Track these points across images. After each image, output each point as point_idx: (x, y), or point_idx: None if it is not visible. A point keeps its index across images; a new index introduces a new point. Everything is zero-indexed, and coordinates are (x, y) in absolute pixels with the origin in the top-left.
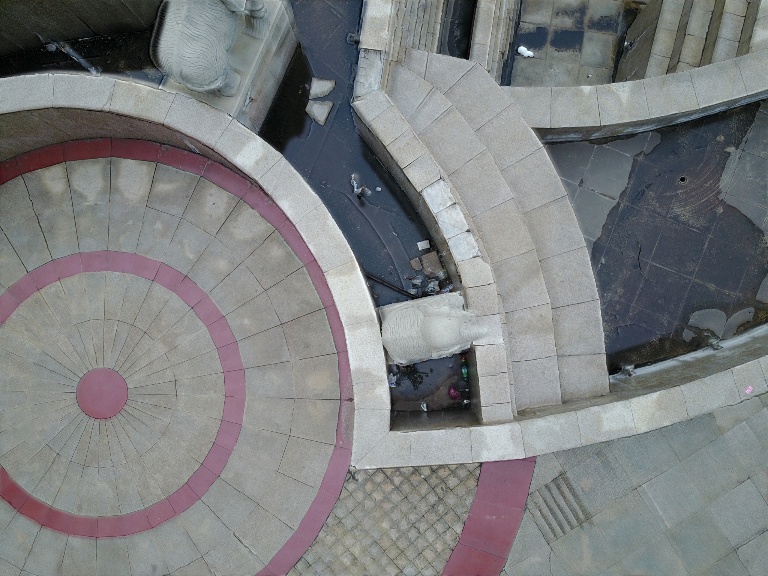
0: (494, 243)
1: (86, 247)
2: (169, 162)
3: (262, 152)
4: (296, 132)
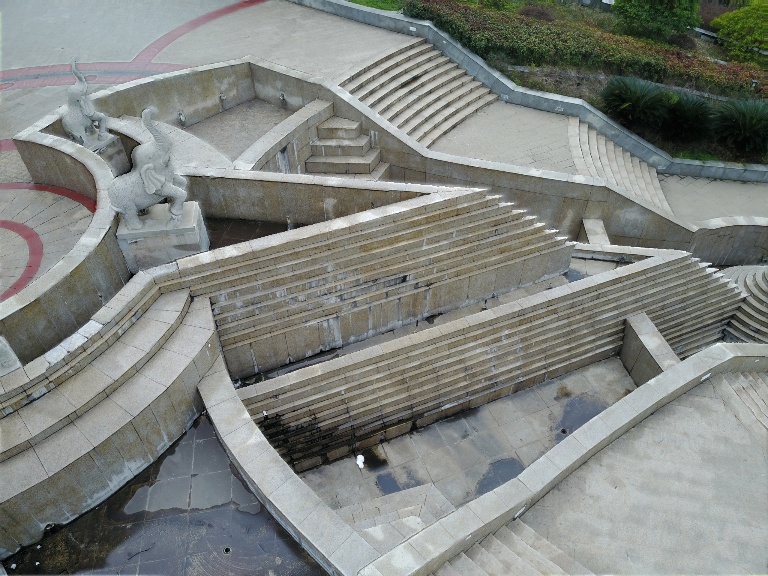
0: (75, 384)
1: (43, 237)
2: None
3: (91, 245)
4: None
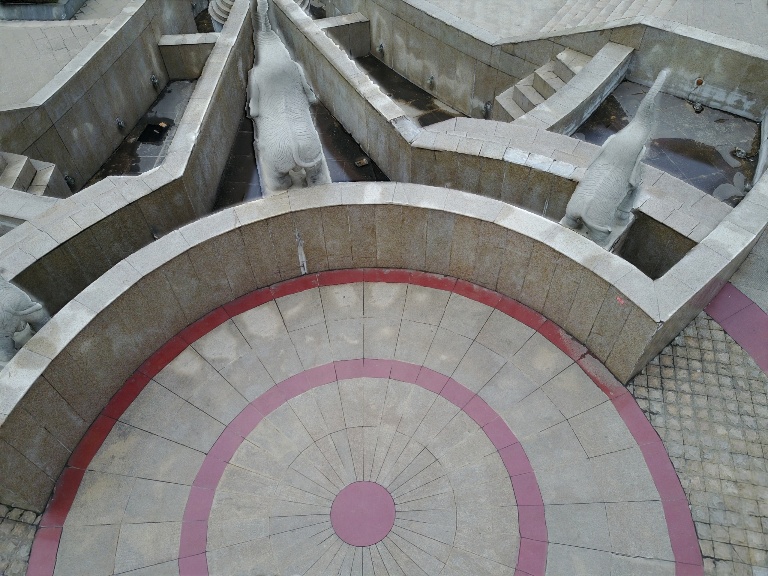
0: None
1: (254, 395)
2: (284, 293)
3: (380, 187)
4: None
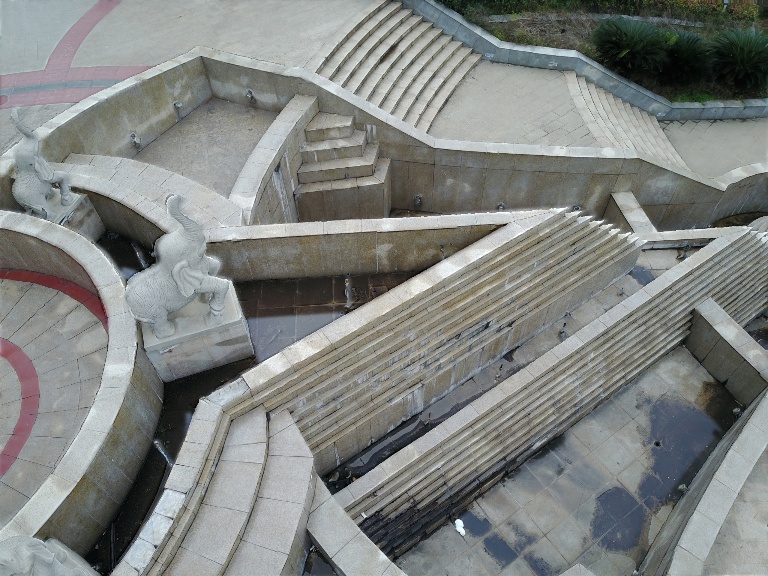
0: None
1: (27, 349)
2: None
3: (123, 375)
4: (193, 399)
